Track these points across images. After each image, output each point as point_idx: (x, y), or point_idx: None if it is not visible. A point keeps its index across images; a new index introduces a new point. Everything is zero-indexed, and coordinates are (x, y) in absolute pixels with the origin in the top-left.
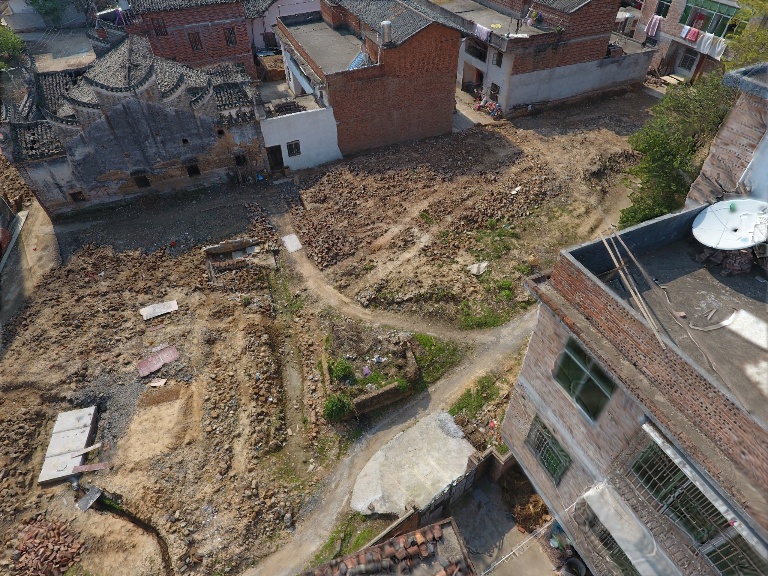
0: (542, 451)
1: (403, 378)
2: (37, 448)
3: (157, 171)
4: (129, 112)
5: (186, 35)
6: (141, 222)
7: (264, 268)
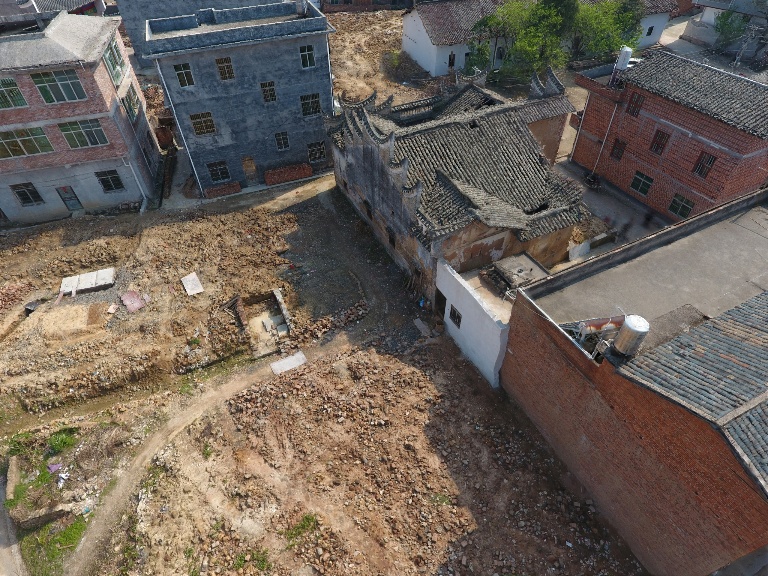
0: None
1: None
2: (91, 268)
3: (376, 215)
4: (373, 156)
5: (655, 129)
6: (333, 236)
7: (250, 347)
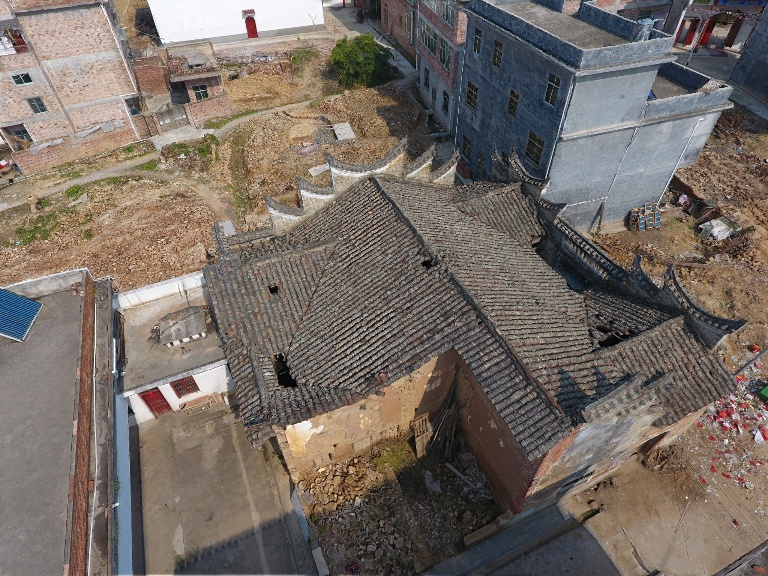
0: None
1: (172, 146)
2: None
3: None
4: None
5: None
6: None
7: None
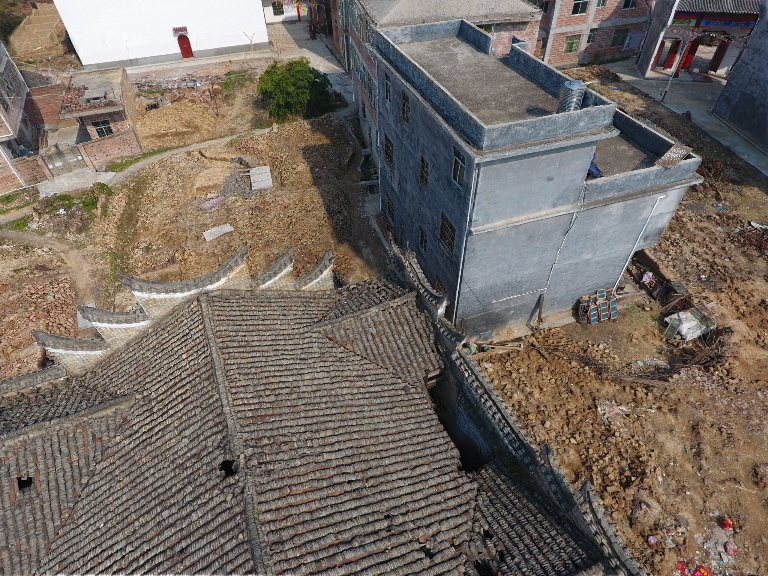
0: (3, 102)
1: (52, 199)
2: None
3: None
4: None
5: None
6: None
7: None
